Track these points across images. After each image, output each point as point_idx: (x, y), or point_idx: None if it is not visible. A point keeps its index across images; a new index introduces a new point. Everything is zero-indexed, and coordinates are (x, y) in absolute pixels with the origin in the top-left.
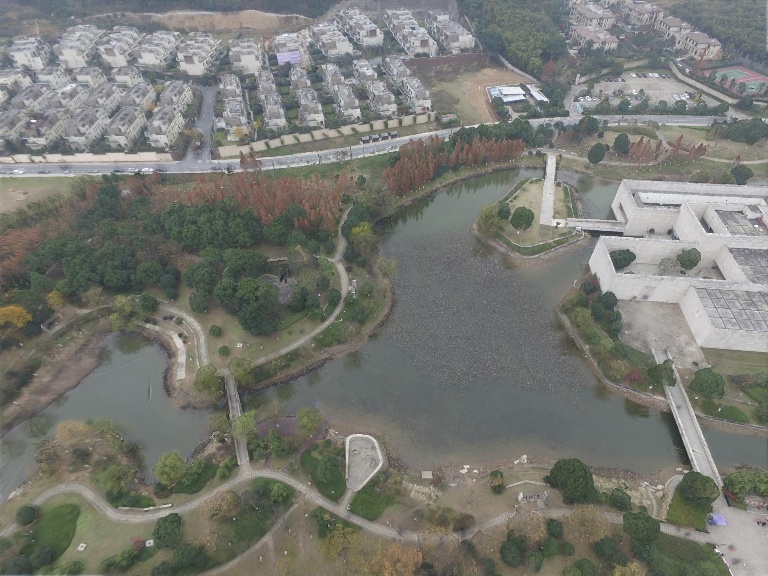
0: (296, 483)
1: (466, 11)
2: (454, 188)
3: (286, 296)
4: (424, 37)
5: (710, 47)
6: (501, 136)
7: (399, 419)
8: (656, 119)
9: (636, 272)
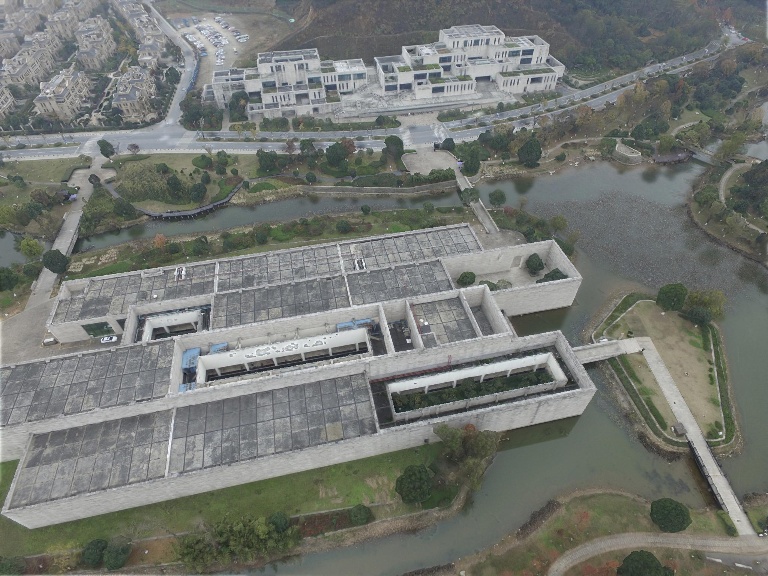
0: (645, 141)
1: None
2: None
3: (766, 182)
4: None
5: None
6: None
7: (625, 174)
8: None
9: None
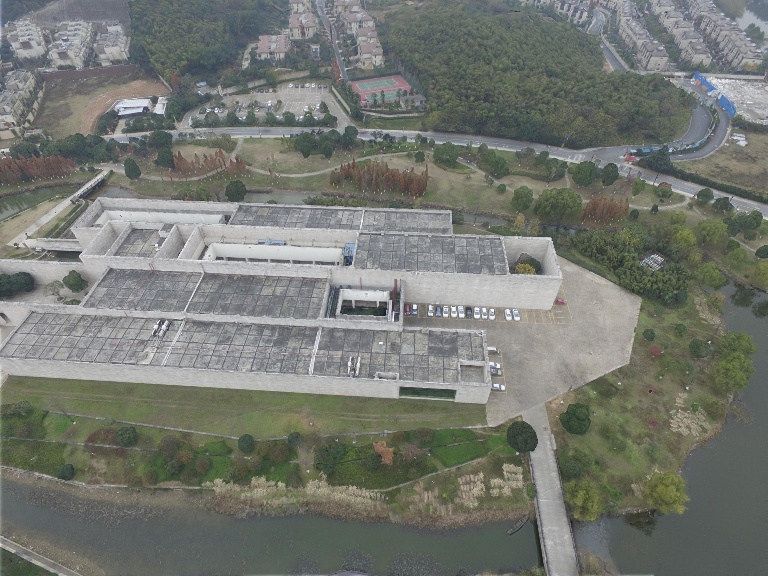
0: None
1: (131, 22)
2: (9, 206)
3: None
4: (65, 49)
5: (372, 57)
6: (53, 152)
7: None
8: (261, 131)
9: (42, 295)
